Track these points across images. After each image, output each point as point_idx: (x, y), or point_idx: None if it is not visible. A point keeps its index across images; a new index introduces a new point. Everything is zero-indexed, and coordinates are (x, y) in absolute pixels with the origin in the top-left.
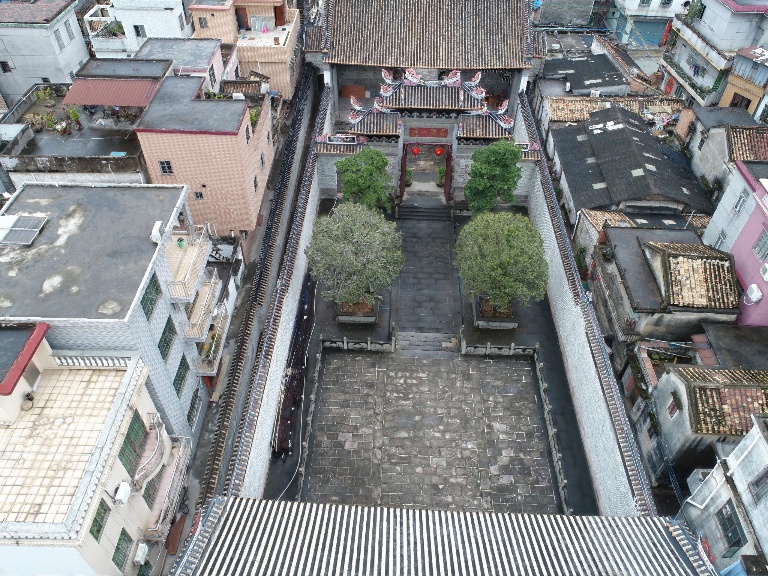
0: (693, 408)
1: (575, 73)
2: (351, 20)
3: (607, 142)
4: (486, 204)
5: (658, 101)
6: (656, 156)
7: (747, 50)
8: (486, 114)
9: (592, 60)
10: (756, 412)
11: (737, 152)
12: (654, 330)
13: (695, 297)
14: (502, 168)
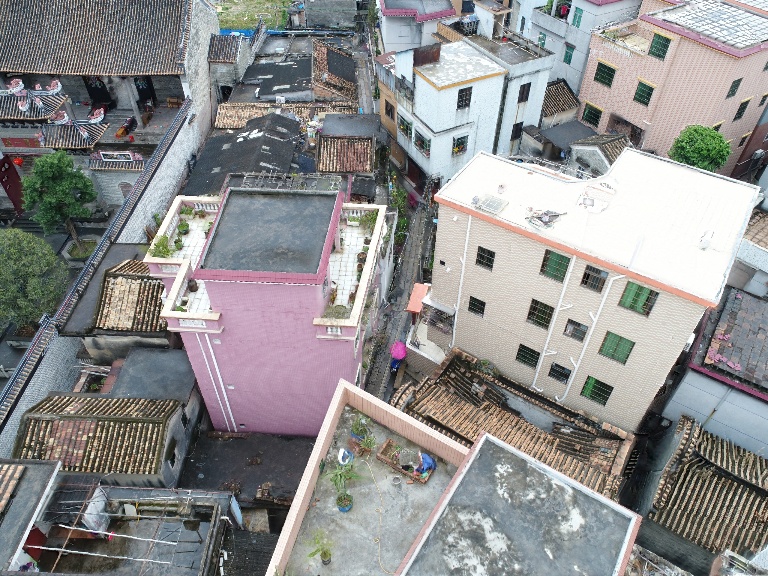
0: (15, 442)
1: (271, 78)
2: (8, 25)
3: (239, 151)
4: (42, 218)
5: (330, 107)
6: (277, 166)
7: (386, 55)
8: (71, 124)
9: (297, 65)
10: (81, 446)
11: (324, 162)
12: (101, 353)
13: (122, 320)
14: (56, 181)
